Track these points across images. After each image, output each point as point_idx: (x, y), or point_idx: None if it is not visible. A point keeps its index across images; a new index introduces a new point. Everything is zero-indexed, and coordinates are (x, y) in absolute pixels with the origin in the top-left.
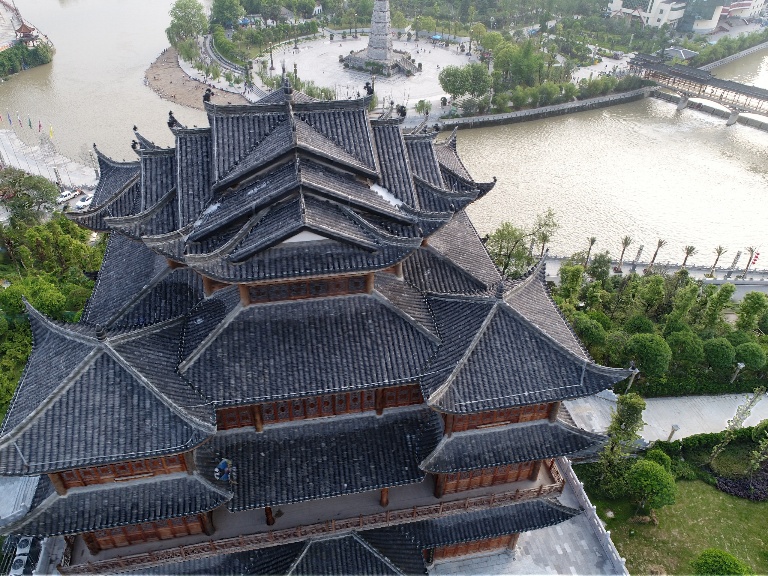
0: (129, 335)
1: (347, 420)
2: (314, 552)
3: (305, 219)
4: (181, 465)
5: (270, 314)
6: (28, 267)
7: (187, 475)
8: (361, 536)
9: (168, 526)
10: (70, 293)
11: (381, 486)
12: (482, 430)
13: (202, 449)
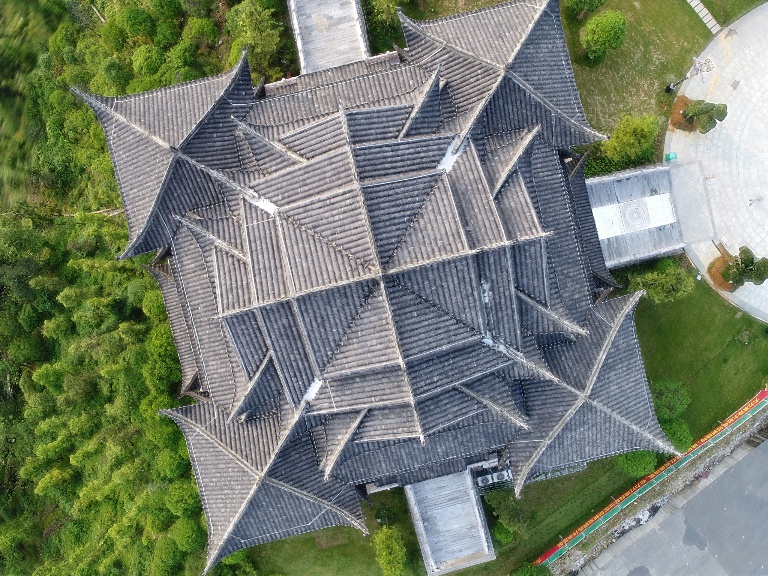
0: None
1: None
2: None
3: None
4: None
5: None
6: None
7: None
8: None
9: None
10: None
11: None
12: None
13: None
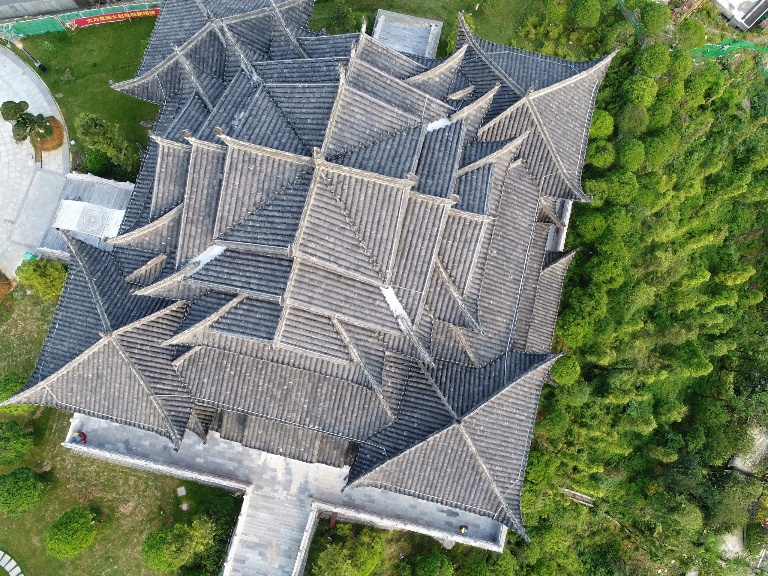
0: None
1: None
2: None
3: None
4: None
5: None
6: (731, 74)
7: None
8: None
9: None
10: (641, 106)
11: None
12: None
13: None
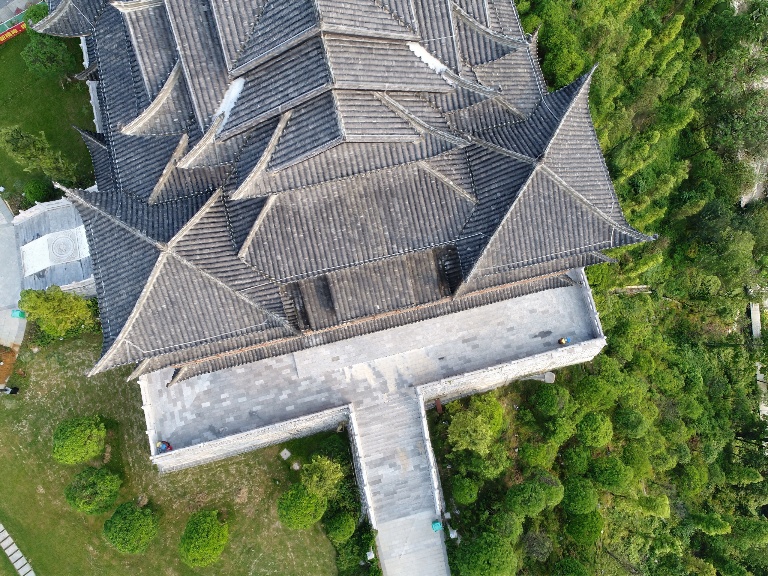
0: None
1: None
2: None
3: None
4: None
5: None
6: None
7: None
8: None
9: None
10: None
11: None
12: None
13: None
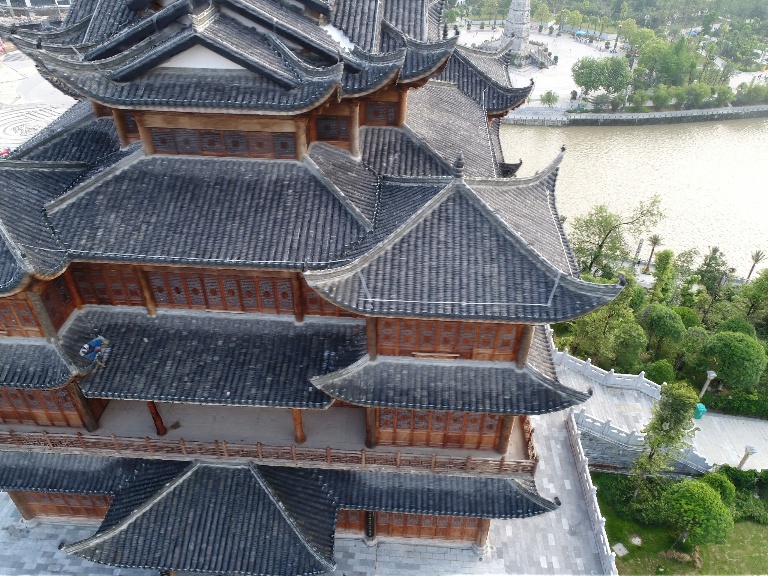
0: (1, 162)
1: (258, 321)
2: (200, 477)
3: (194, 24)
4: (39, 328)
5: (173, 167)
6: None
7: (47, 343)
8: (259, 471)
9: (42, 408)
10: None
11: (270, 403)
12: (419, 360)
13: (81, 321)
